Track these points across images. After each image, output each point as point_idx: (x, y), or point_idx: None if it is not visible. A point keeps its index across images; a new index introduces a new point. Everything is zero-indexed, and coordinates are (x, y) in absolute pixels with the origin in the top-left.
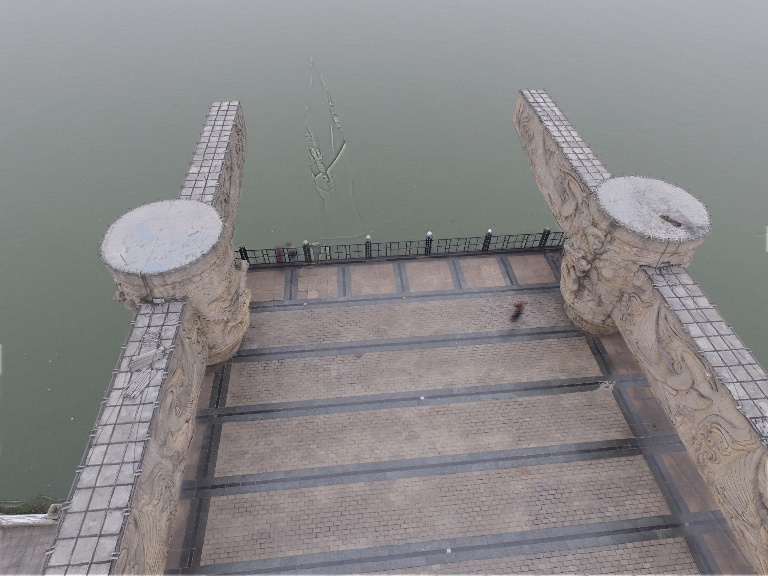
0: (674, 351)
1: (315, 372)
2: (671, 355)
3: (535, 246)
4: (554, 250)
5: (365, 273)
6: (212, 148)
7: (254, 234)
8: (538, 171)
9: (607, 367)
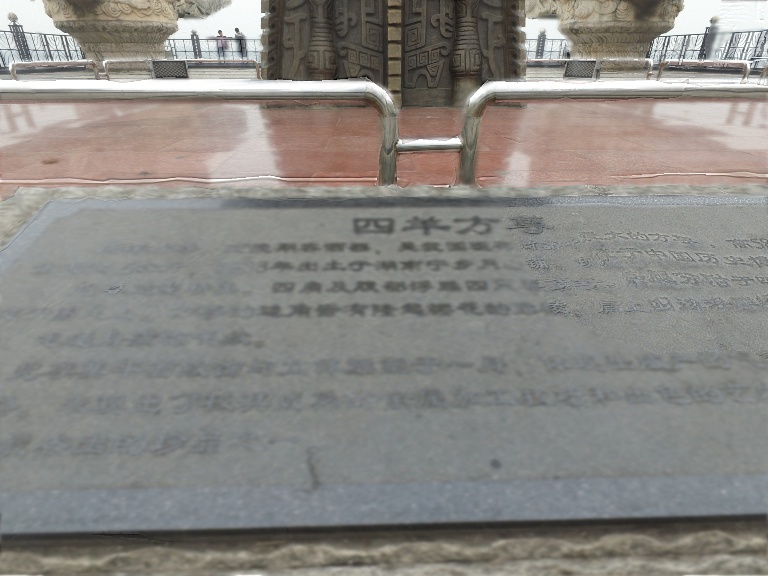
0: None
1: (241, 72)
2: None
3: (531, 62)
4: (554, 66)
5: None
6: None
7: None
8: (528, 0)
9: (629, 72)
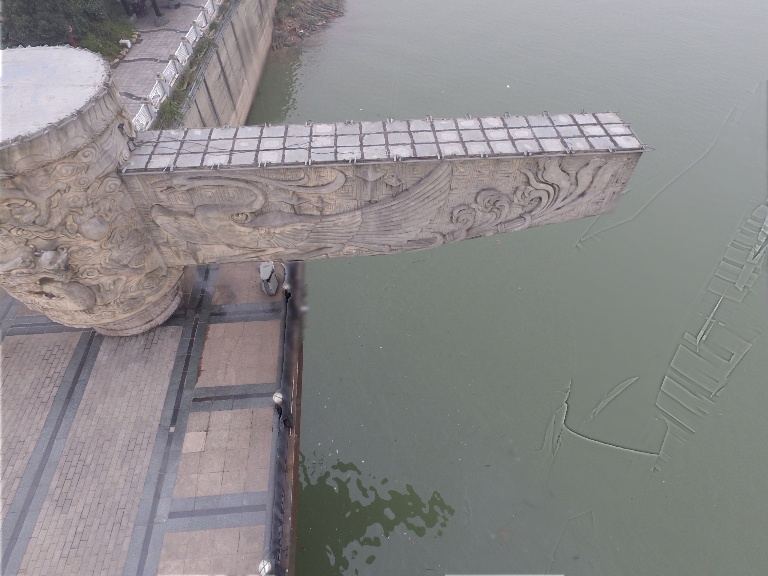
0: None
1: None
2: None
3: None
4: None
5: (232, 569)
6: (409, 138)
7: (320, 301)
8: None
9: None
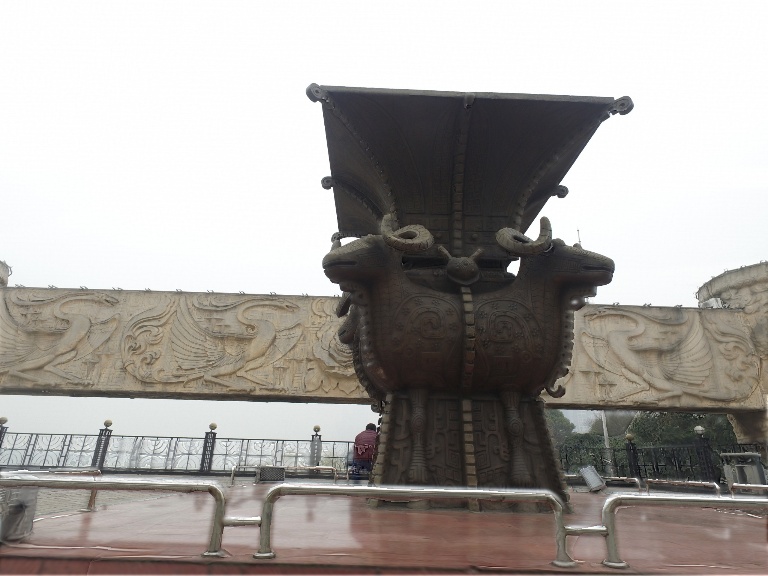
0: (49, 319)
1: None
2: (47, 326)
3: None
4: None
5: None
6: None
7: None
8: None
9: None
